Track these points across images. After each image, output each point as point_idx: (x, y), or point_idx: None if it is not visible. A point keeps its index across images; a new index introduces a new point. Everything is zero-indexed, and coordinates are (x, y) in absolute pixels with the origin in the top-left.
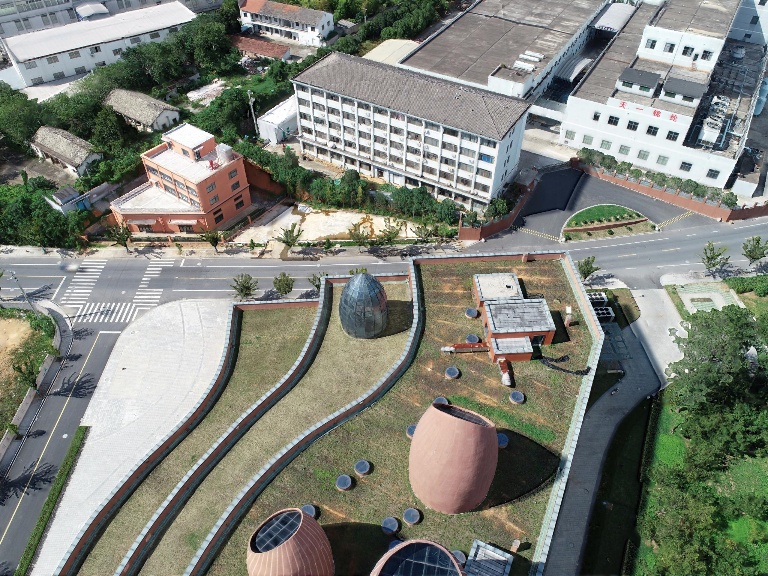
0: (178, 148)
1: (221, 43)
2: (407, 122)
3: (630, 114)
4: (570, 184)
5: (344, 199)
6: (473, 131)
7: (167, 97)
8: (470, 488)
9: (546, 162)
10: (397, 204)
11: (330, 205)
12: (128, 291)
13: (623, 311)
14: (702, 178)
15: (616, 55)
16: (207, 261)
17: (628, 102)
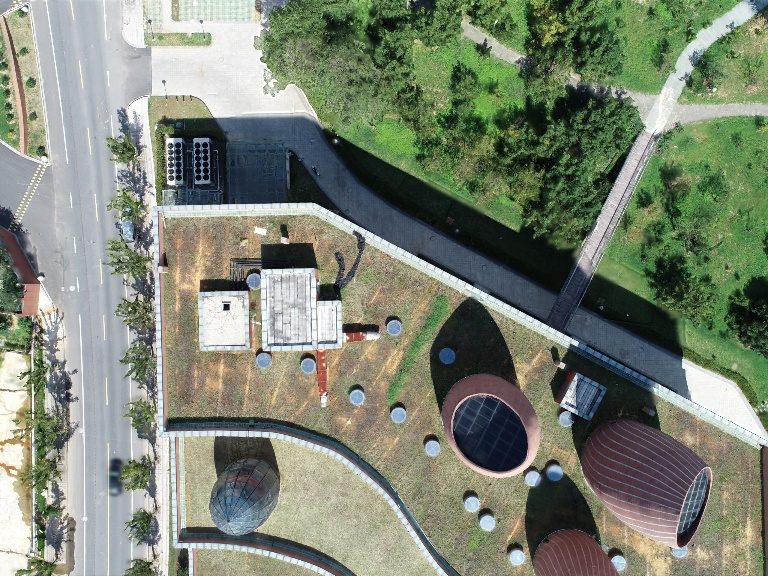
0: None
1: None
2: None
3: None
4: None
5: None
6: None
7: None
8: None
9: None
10: None
11: None
12: None
13: (191, 119)
14: None
15: None
16: None
17: None
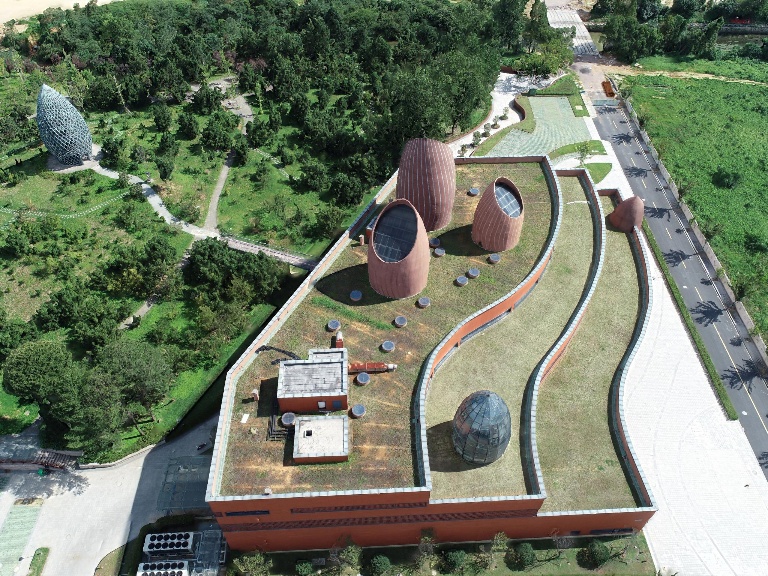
0: None
1: None
2: None
3: None
4: None
5: None
6: None
7: None
8: None
9: None
10: None
11: None
12: None
13: (120, 568)
14: None
15: None
16: None
17: None
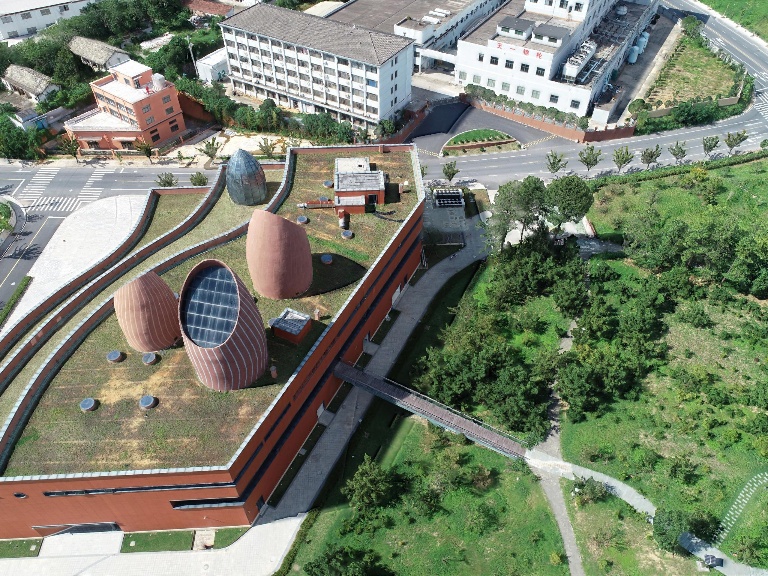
0: (121, 78)
1: (171, 1)
2: (310, 55)
3: (506, 54)
4: (456, 114)
5: (262, 124)
6: (359, 59)
7: (122, 45)
8: (283, 270)
9: (440, 98)
10: (306, 127)
11: (252, 130)
12: (75, 190)
13: (477, 204)
14: (567, 108)
15: (510, 10)
16: (142, 169)
17: (503, 43)
